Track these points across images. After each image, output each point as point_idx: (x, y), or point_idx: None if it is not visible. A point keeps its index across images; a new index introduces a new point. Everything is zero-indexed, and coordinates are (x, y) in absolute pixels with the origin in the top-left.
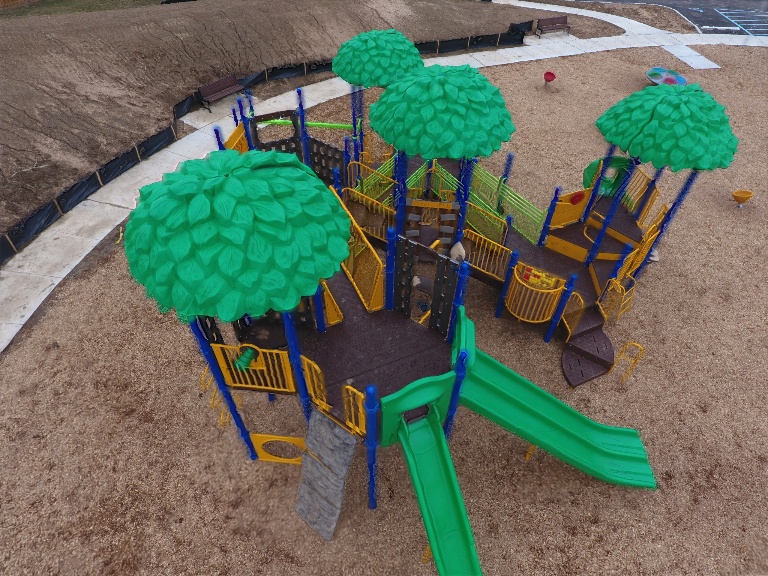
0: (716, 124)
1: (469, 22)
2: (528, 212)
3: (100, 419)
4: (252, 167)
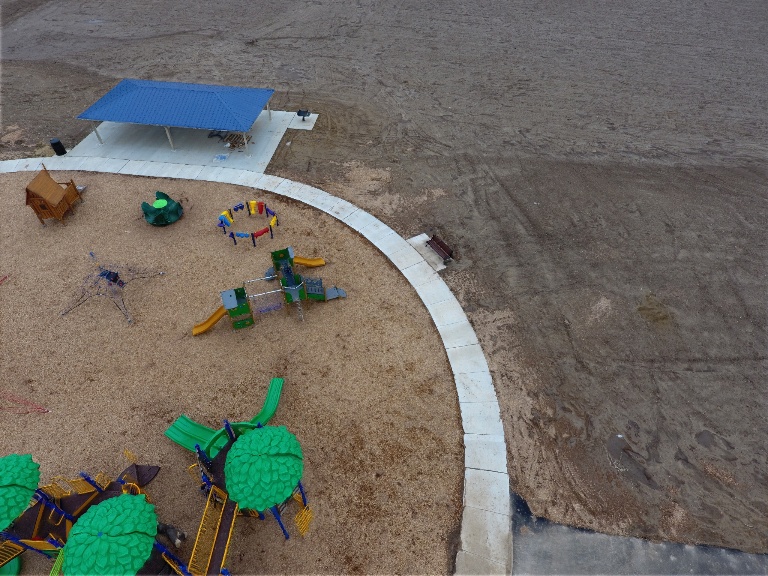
0: None
1: None
2: (58, 567)
3: (370, 571)
4: (250, 454)
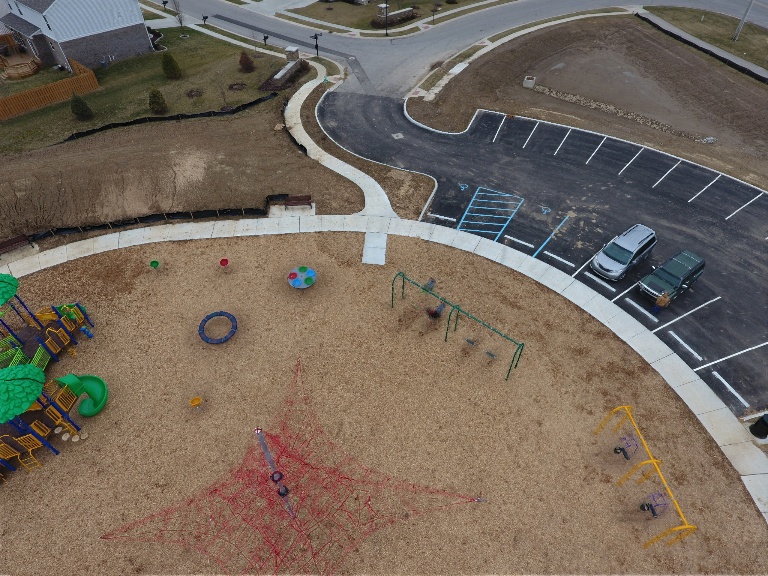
0: (2, 401)
1: (245, 188)
2: None
3: None
4: None
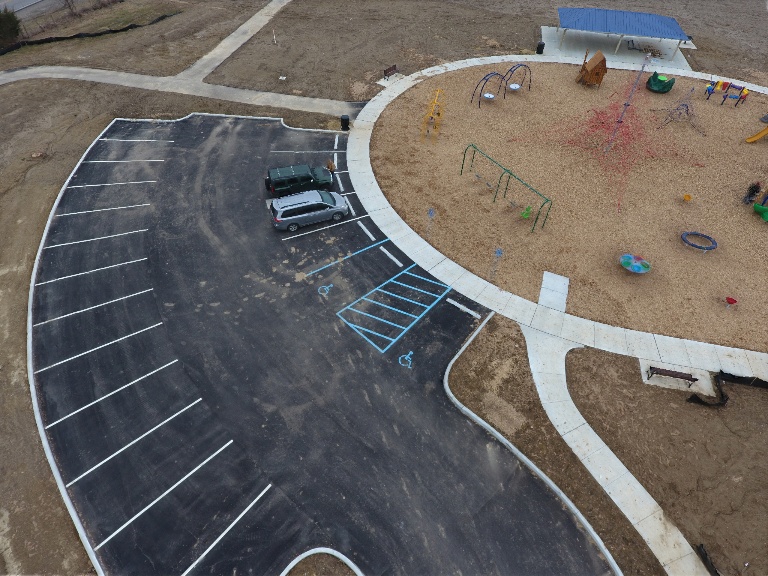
0: None
1: None
2: None
3: None
4: None
